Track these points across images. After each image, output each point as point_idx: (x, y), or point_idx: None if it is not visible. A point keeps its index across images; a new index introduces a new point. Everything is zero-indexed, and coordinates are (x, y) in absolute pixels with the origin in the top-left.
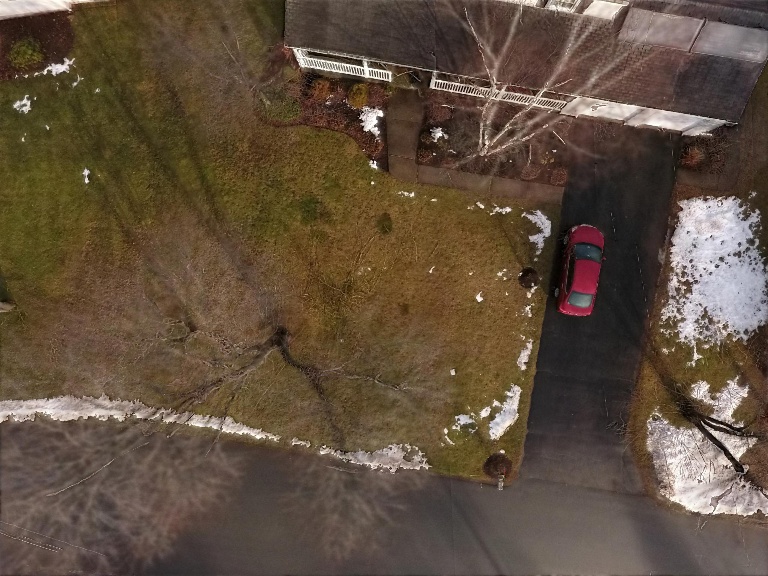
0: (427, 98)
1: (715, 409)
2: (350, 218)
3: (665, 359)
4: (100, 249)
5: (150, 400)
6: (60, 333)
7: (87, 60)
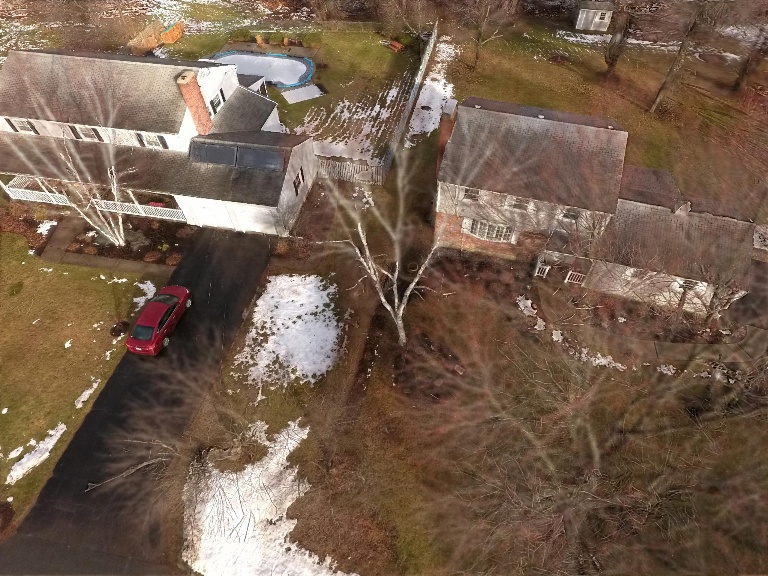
0: None
1: (270, 451)
2: None
3: (228, 399)
4: None
5: None
6: None
7: None
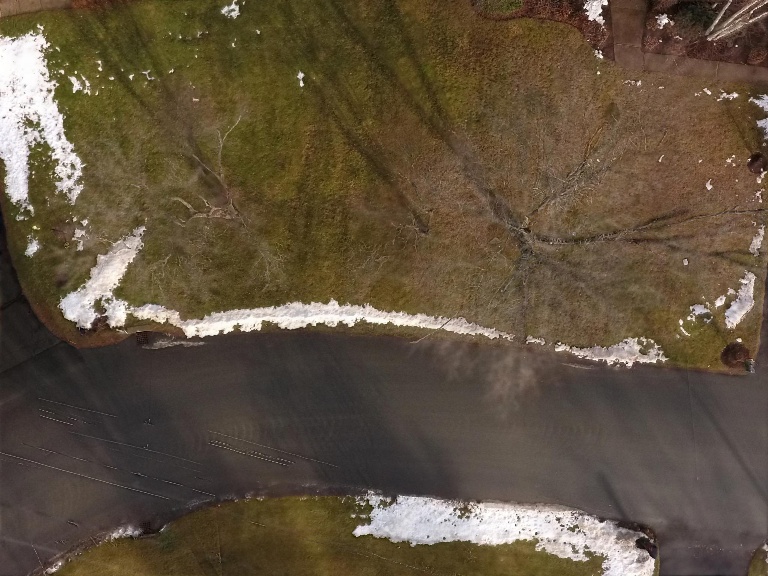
0: None
1: None
2: (577, 109)
3: None
4: (320, 152)
5: (380, 303)
6: (285, 238)
7: None
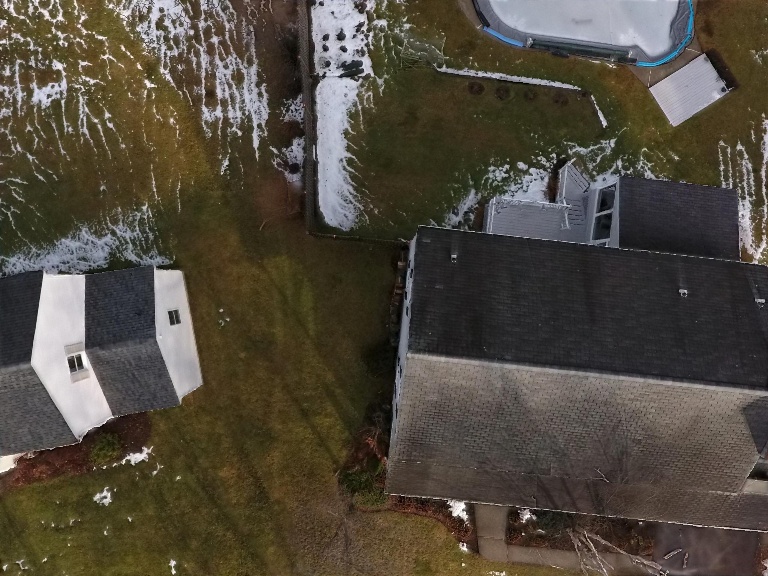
0: None
1: None
2: None
3: None
4: None
5: None
6: None
7: (166, 448)
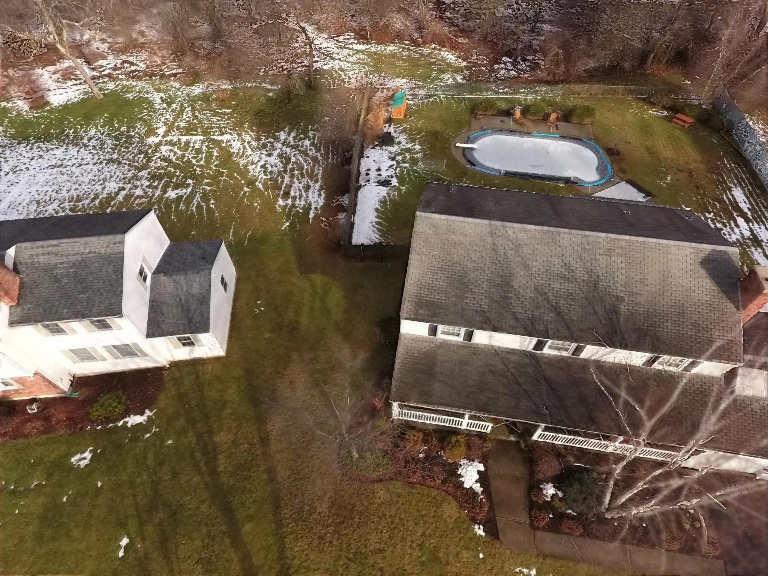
0: (531, 450)
1: None
2: None
3: None
4: None
5: None
6: None
7: (169, 411)
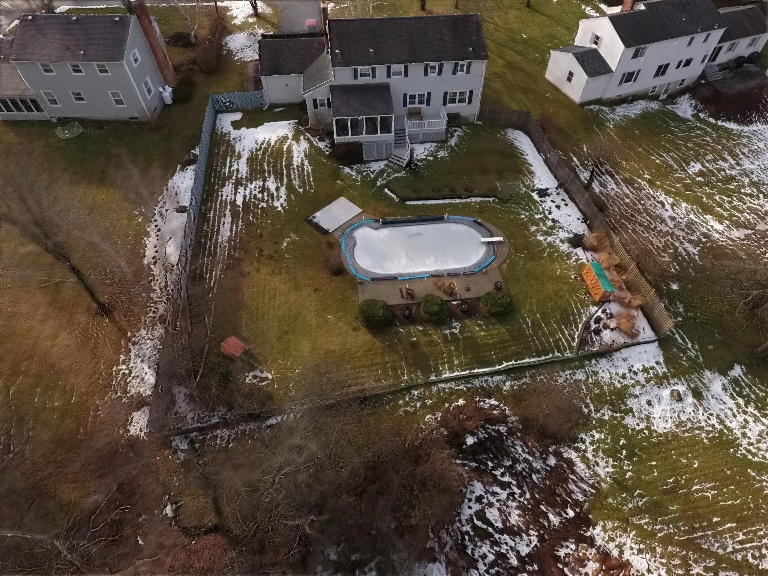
0: None
1: None
2: None
3: None
4: None
5: None
6: (504, 2)
7: None
